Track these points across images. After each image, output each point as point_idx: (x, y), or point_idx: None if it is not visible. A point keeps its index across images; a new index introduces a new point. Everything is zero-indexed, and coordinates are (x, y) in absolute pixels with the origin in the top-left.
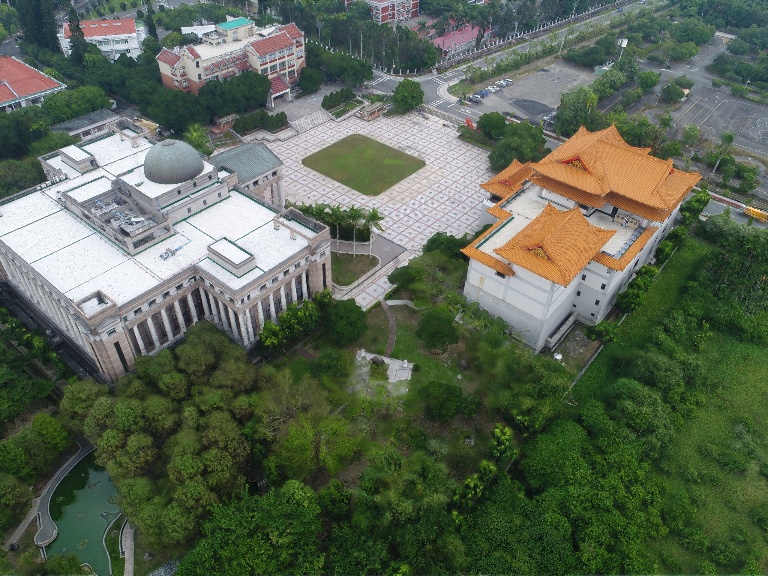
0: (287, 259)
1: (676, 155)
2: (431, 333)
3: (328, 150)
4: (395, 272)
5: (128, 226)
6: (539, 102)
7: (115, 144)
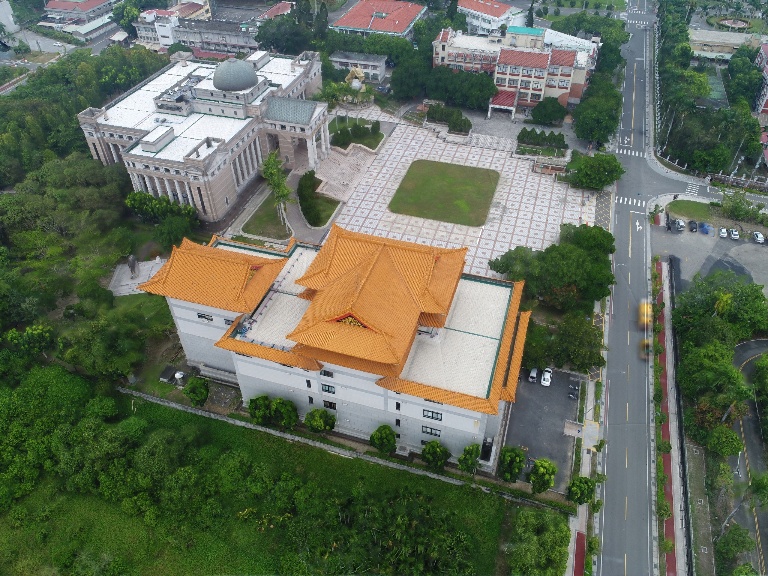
0: (164, 159)
1: None
2: None
3: (450, 166)
4: None
5: None
6: None
7: None
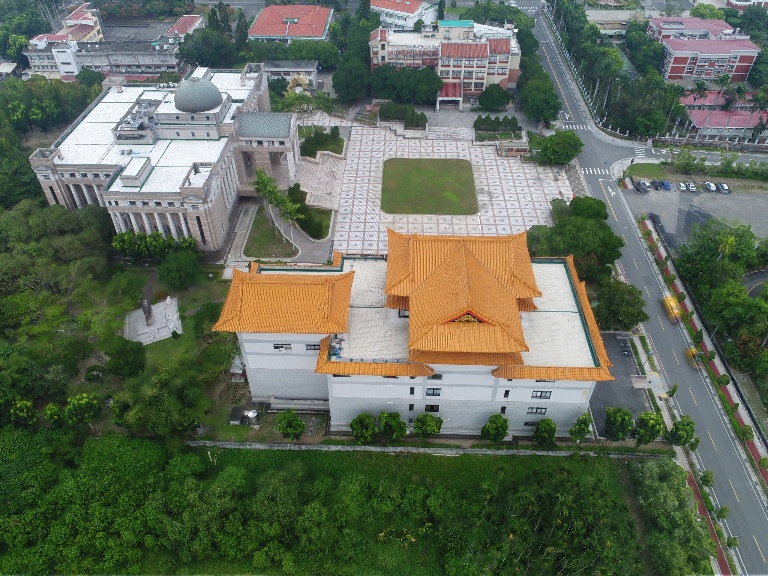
0: (155, 192)
1: None
2: (197, 316)
3: (421, 161)
4: None
5: None
6: None
7: (238, 79)
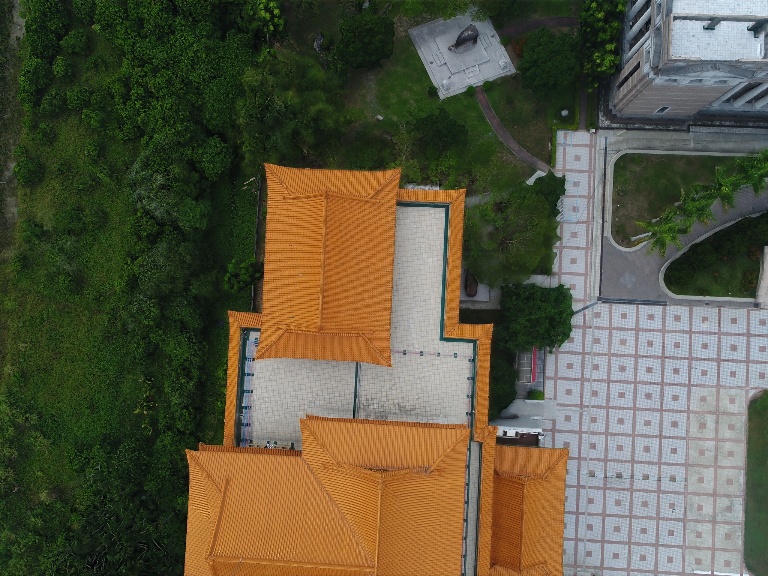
0: None
1: None
2: None
3: None
4: (557, 181)
5: None
6: None
7: None
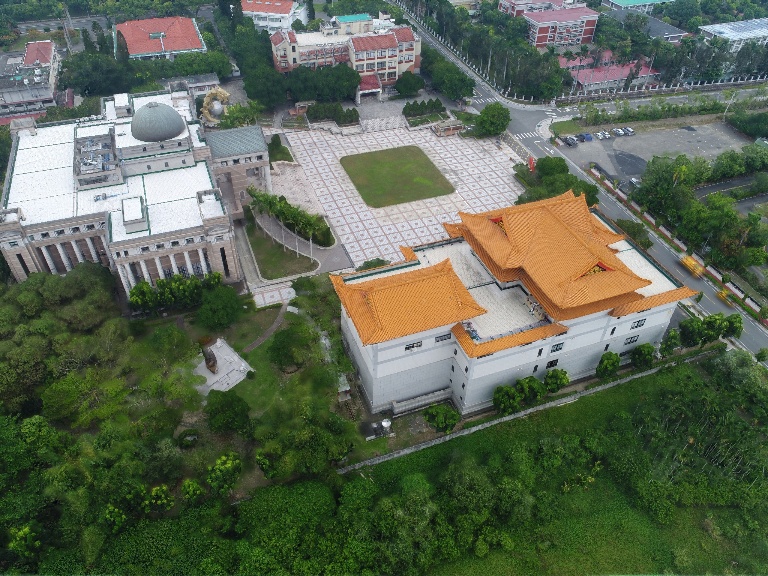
0: (173, 231)
1: (756, 265)
2: (275, 347)
3: (374, 154)
4: (297, 280)
5: (83, 165)
6: (647, 161)
7: (164, 101)
